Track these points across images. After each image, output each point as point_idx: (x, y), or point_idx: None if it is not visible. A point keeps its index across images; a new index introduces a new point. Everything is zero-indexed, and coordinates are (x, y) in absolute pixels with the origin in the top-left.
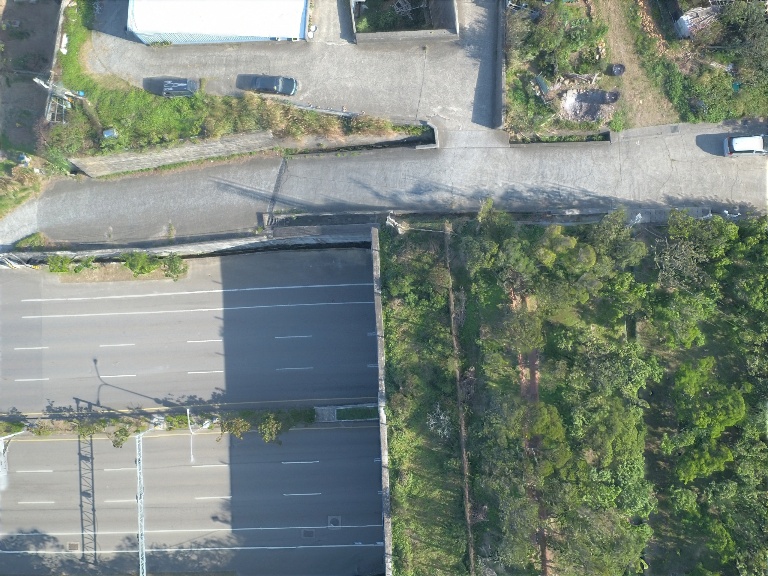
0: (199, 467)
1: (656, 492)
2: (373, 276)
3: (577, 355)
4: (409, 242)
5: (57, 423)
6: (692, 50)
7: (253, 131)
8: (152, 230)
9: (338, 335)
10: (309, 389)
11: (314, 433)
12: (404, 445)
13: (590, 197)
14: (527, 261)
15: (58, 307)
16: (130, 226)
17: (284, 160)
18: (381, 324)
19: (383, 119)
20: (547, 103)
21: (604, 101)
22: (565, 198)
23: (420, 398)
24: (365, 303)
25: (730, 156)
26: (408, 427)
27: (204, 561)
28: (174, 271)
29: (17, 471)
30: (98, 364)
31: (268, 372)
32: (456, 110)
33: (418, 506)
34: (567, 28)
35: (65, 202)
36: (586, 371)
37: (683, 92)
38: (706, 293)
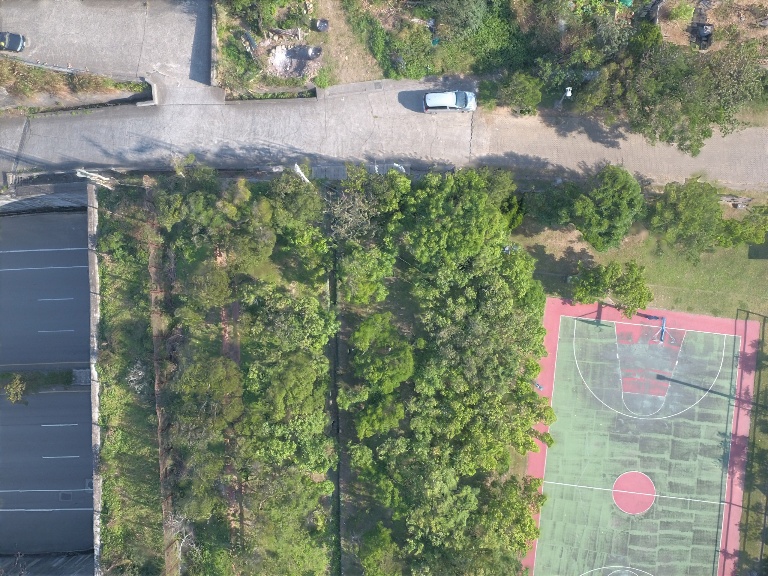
0: None
1: (340, 449)
2: None
3: (260, 310)
4: (124, 199)
5: None
6: (395, 6)
7: None
8: None
9: None
10: (69, 352)
11: (73, 396)
12: (115, 402)
13: (297, 154)
14: (212, 215)
15: None
16: None
17: (27, 119)
18: (94, 281)
19: (105, 75)
20: (254, 59)
21: (309, 57)
22: (274, 155)
23: (131, 355)
24: None
25: (429, 113)
26: (118, 384)
27: None
28: None
29: None
30: None
31: (30, 334)
32: (174, 67)
33: (127, 463)
34: None
35: None
36: (265, 326)
37: (385, 48)
38: (383, 248)
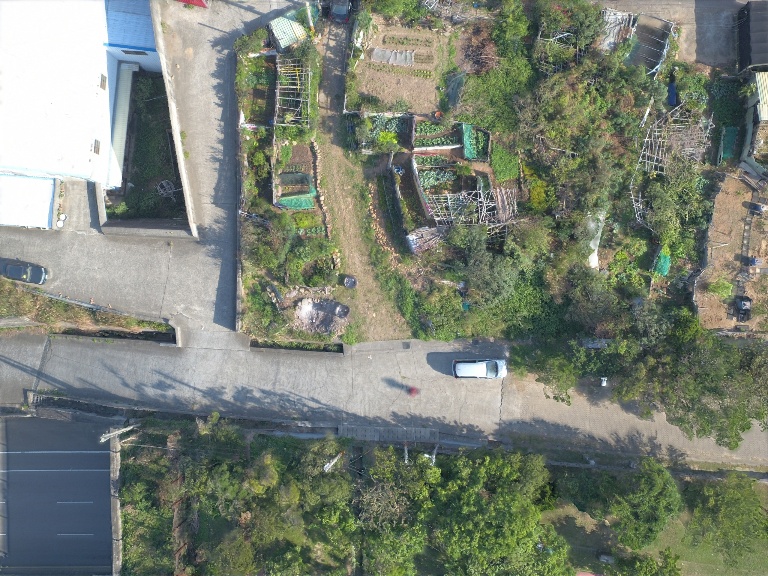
0: None
1: None
2: (110, 478)
3: None
4: (147, 444)
5: None
6: (424, 265)
7: (5, 318)
8: None
9: None
10: (89, 556)
11: None
12: None
13: (323, 409)
14: (237, 489)
15: None
16: None
17: (48, 338)
18: (117, 527)
19: (128, 314)
20: (280, 312)
21: None
22: (300, 408)
23: None
24: None
25: None
26: None
27: None
28: None
29: None
30: None
31: (49, 537)
32: (198, 309)
33: None
34: (303, 235)
35: None
36: None
37: (413, 309)
38: (412, 532)
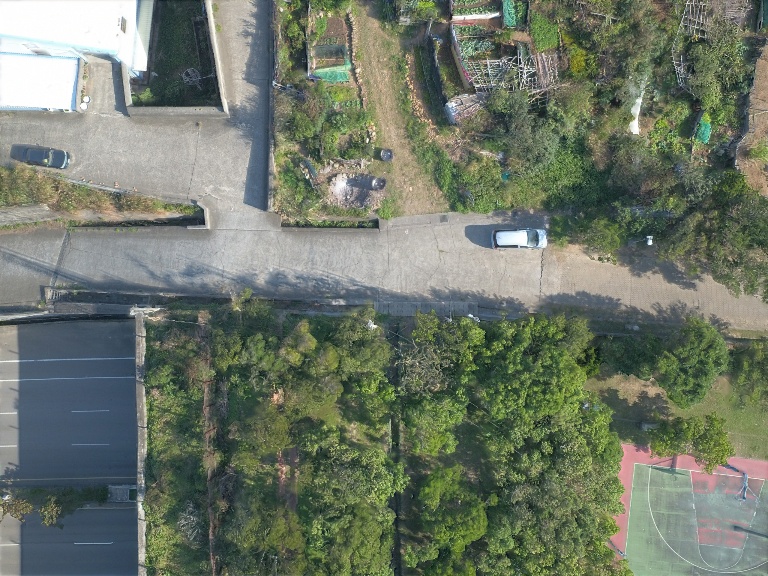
0: None
1: None
2: None
3: None
4: (174, 328)
5: None
6: (462, 137)
7: (24, 204)
8: None
9: None
10: (105, 466)
11: (108, 513)
12: (162, 543)
13: (358, 287)
14: (273, 359)
15: None
16: None
17: (67, 232)
18: (142, 414)
19: (154, 197)
20: (314, 187)
21: None
22: (333, 287)
23: (181, 493)
24: None
25: (497, 249)
26: (166, 524)
27: None
28: None
29: None
30: None
31: (63, 448)
32: (228, 190)
33: None
34: (337, 109)
35: None
36: (330, 477)
37: (451, 181)
38: (455, 398)
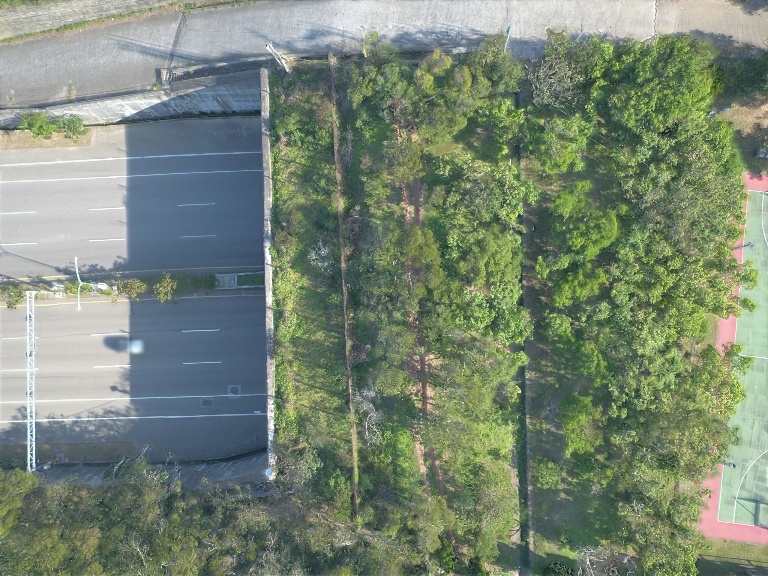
0: (98, 335)
1: (533, 321)
2: (261, 116)
3: (455, 181)
4: (298, 83)
5: None
6: None
7: None
8: (53, 91)
9: (241, 203)
10: (211, 257)
11: (215, 301)
12: (289, 286)
13: (477, 36)
14: (406, 86)
15: None
16: (31, 88)
17: (183, 15)
18: (268, 164)
19: None
20: None
21: None
22: (453, 38)
23: (306, 239)
24: None
25: None
26: (293, 267)
27: (101, 431)
28: (73, 131)
29: None
30: None
31: (170, 240)
32: None
33: (302, 347)
34: None
35: None
36: (462, 195)
37: None
38: (582, 116)
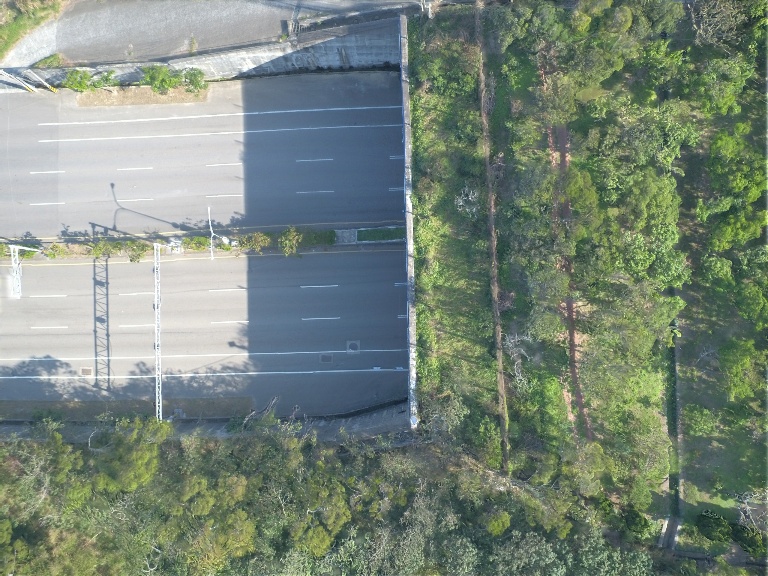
0: (216, 291)
1: (689, 266)
2: None
3: (611, 124)
4: (438, 30)
5: (72, 247)
6: None
7: None
8: (173, 45)
9: (360, 158)
10: (329, 213)
11: (334, 257)
12: (430, 234)
13: None
14: (561, 28)
15: (75, 131)
16: (151, 42)
17: None
18: (408, 112)
19: None
20: None
21: None
22: None
23: (447, 187)
24: (388, 126)
25: None
26: (435, 215)
27: (219, 387)
28: (195, 84)
29: (30, 296)
30: (115, 188)
31: (288, 196)
32: None
33: (443, 296)
34: None
35: (85, 22)
36: (620, 137)
37: None
38: (744, 57)
